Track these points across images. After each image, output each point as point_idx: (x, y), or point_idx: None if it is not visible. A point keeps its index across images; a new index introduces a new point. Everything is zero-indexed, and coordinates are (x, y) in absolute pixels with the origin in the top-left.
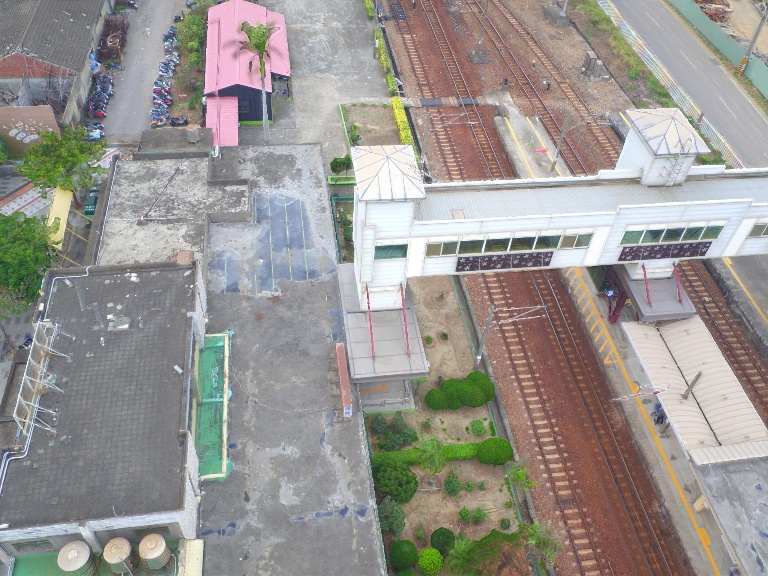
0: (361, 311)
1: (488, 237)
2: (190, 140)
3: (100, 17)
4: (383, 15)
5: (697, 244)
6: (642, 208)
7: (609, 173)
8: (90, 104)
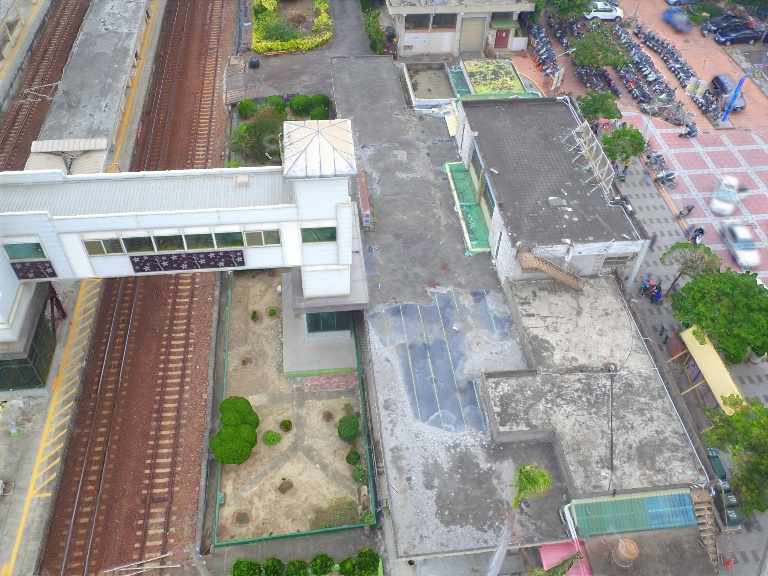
0: None
1: None
2: None
3: None
4: None
5: None
6: None
7: None
8: None
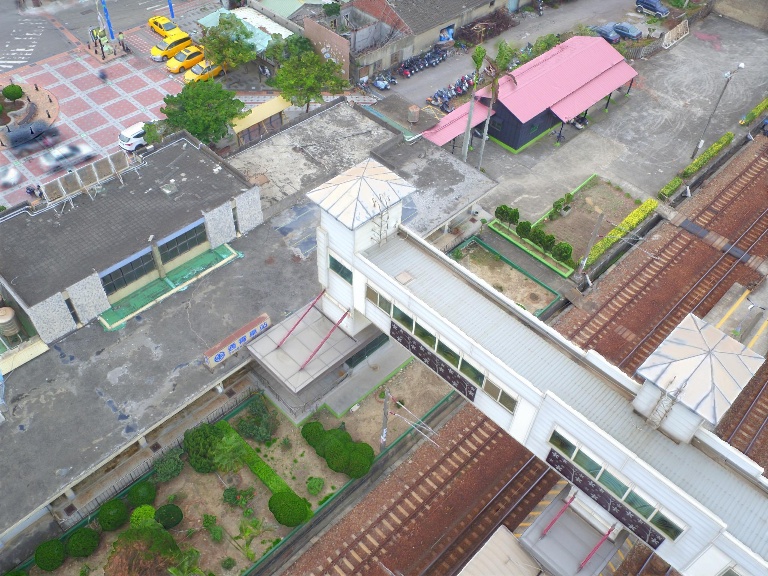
0: (323, 312)
1: (416, 319)
2: (408, 118)
3: (490, 5)
4: (767, 129)
5: (644, 523)
6: (572, 414)
7: (599, 360)
8: (405, 62)
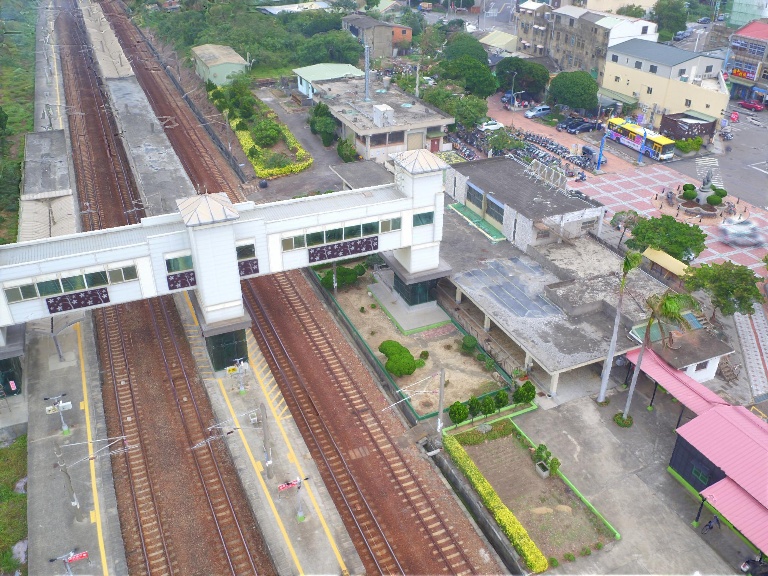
0: None
1: None
2: None
3: None
4: None
5: None
6: (236, 205)
7: None
8: None
